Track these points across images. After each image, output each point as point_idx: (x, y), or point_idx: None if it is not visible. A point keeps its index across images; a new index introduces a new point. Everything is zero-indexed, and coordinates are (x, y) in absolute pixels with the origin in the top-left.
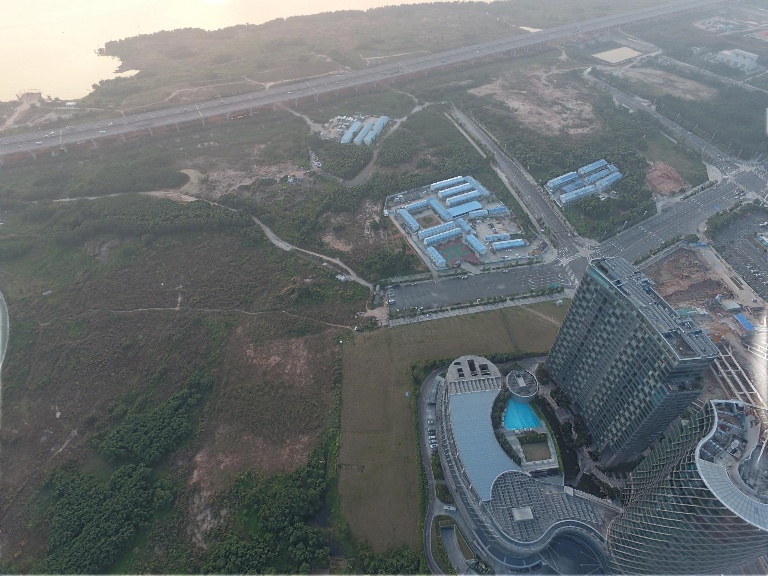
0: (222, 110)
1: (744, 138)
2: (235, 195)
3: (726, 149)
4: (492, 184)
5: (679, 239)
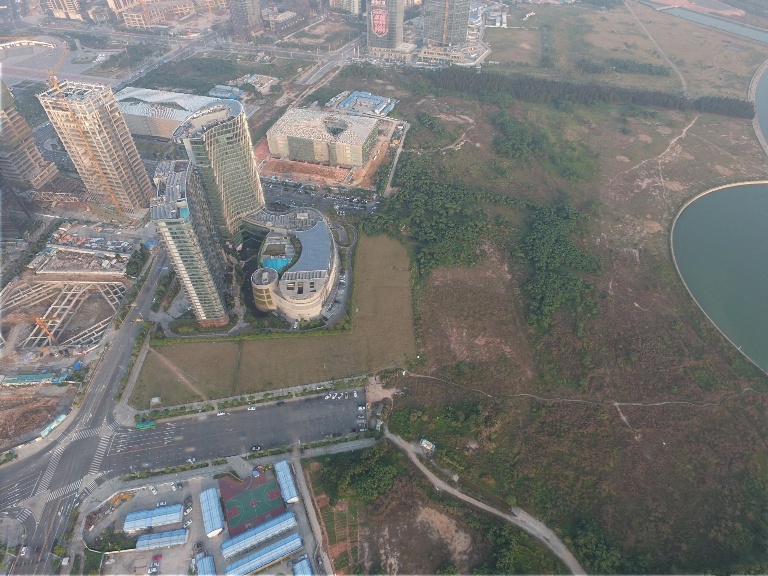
0: None
1: None
2: None
3: None
4: None
5: None
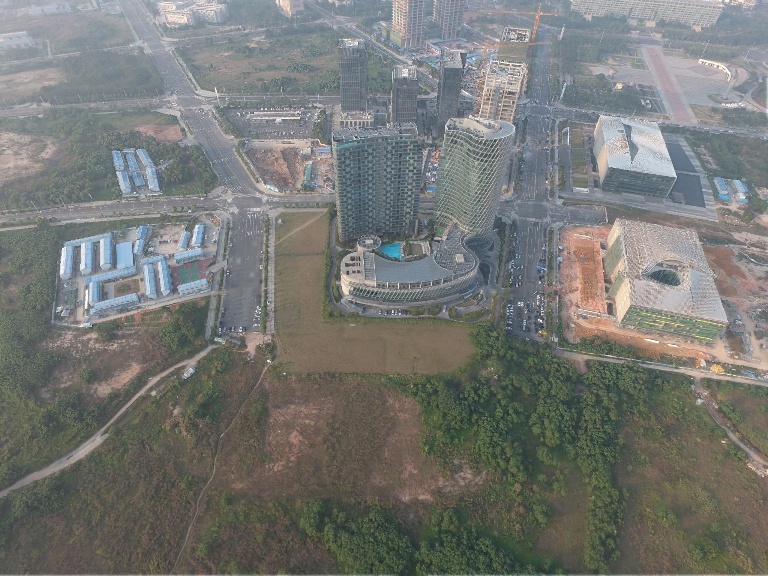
0: None
1: (138, 84)
2: None
3: (145, 95)
4: (92, 230)
5: None
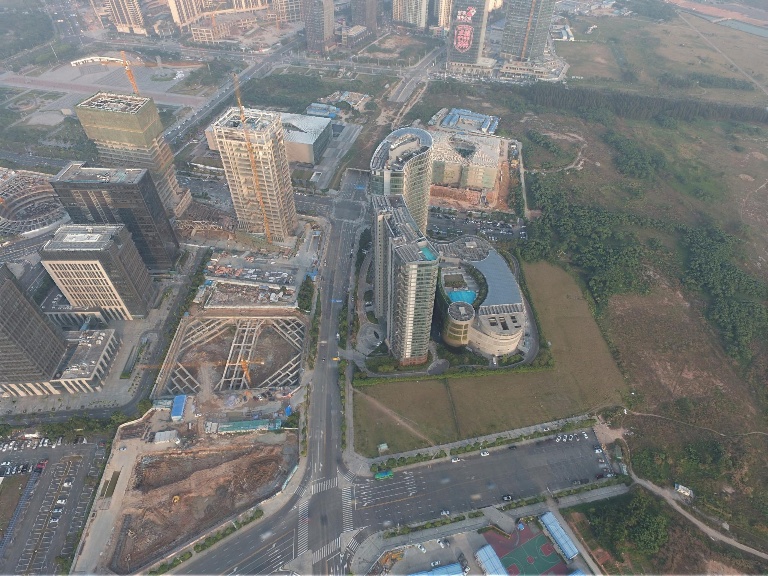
0: None
1: None
2: None
3: None
4: None
5: None
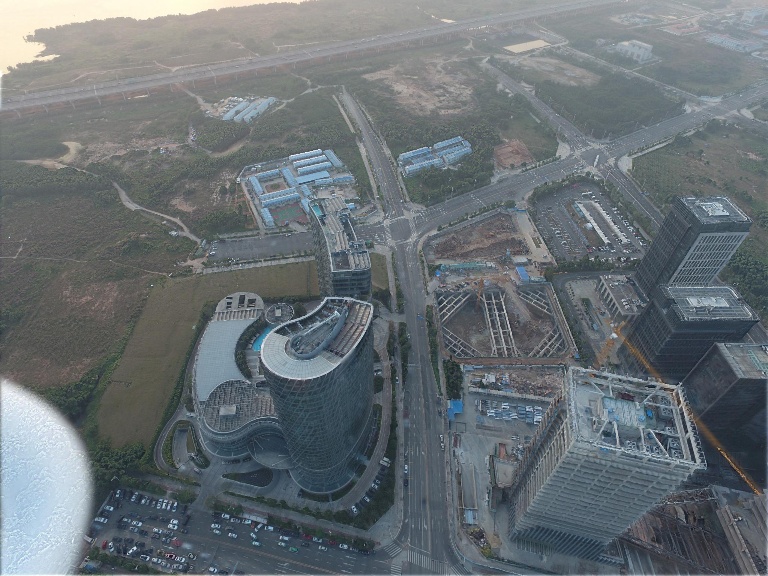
0: (117, 90)
1: (604, 119)
2: (103, 163)
3: (583, 129)
4: (349, 157)
5: (501, 205)
